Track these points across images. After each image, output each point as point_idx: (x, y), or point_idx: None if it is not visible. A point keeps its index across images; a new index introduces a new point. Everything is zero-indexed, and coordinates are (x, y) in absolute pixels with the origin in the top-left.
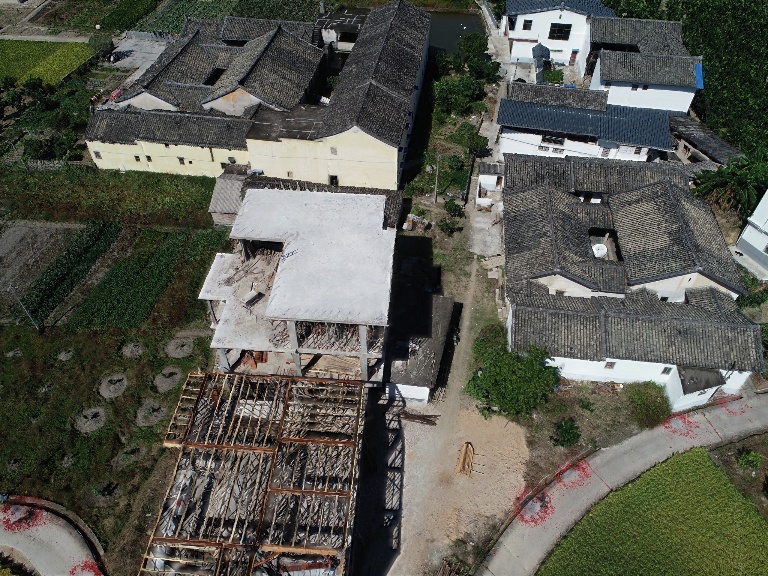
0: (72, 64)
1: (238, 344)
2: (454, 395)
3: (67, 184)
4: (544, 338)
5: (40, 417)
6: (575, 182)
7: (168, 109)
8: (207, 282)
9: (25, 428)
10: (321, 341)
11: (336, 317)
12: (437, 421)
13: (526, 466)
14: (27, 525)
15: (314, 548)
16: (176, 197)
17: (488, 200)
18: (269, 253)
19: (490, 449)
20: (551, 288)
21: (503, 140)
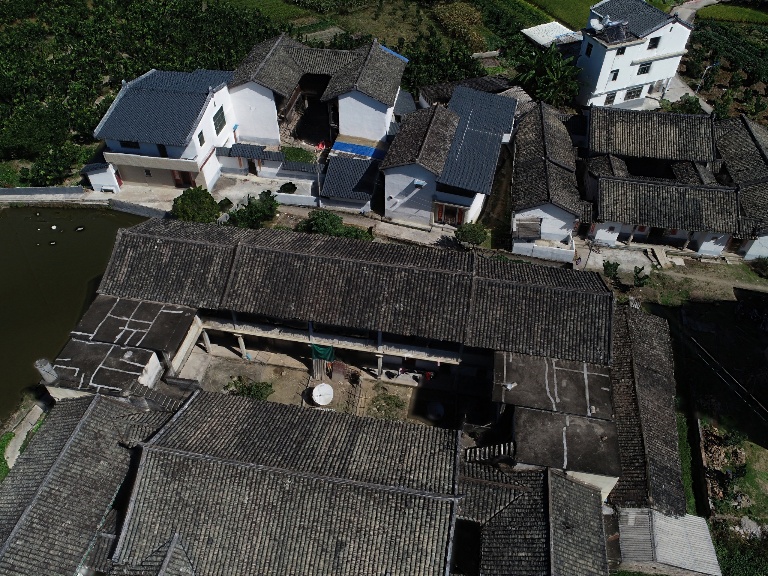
0: None
1: None
2: None
3: None
4: None
5: None
6: None
7: None
8: None
9: None
10: None
11: None
12: None
13: None
14: None
15: None
16: None
17: None
18: None
19: None
20: None
21: (469, 211)
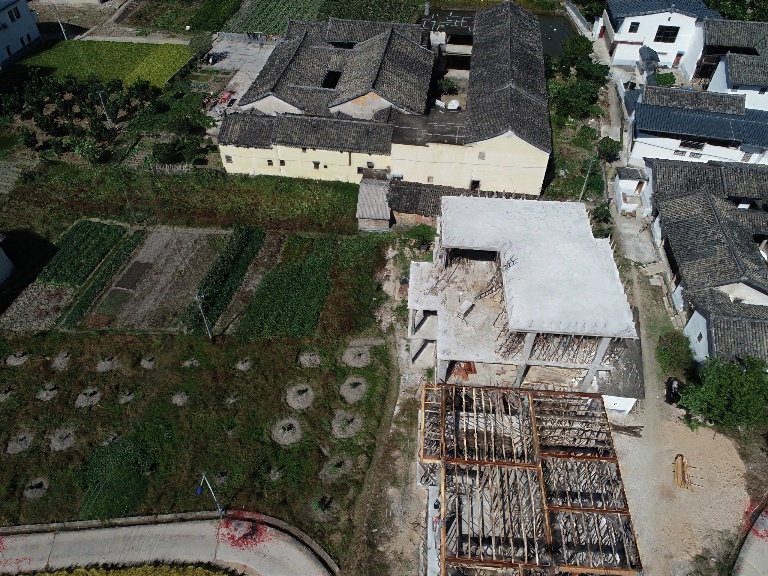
0: (172, 66)
1: (465, 356)
2: (651, 406)
3: (198, 189)
4: (746, 348)
5: (235, 429)
6: (728, 188)
7: (293, 112)
8: (411, 291)
9: (223, 440)
10: (548, 353)
11: (583, 329)
12: (642, 433)
13: (746, 479)
14: (253, 541)
15: (614, 569)
16: (312, 202)
17: (634, 205)
18: (466, 262)
19: (704, 461)
20: (730, 296)
21: (636, 144)
